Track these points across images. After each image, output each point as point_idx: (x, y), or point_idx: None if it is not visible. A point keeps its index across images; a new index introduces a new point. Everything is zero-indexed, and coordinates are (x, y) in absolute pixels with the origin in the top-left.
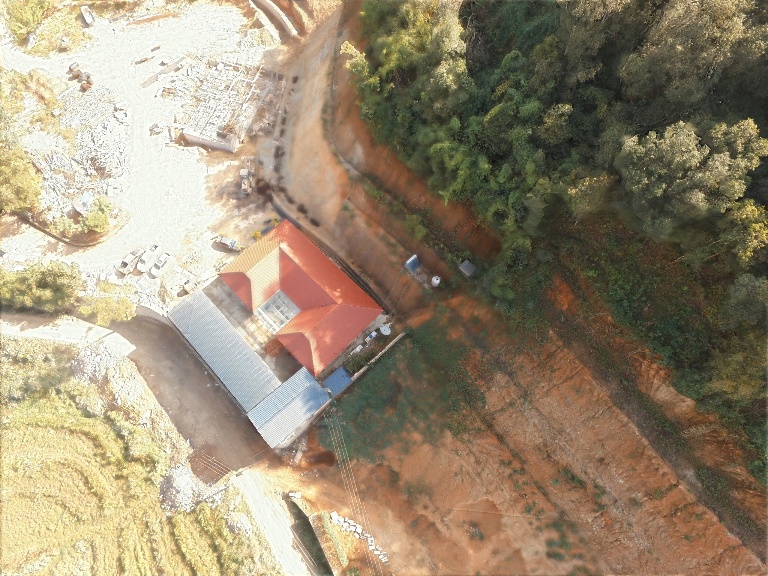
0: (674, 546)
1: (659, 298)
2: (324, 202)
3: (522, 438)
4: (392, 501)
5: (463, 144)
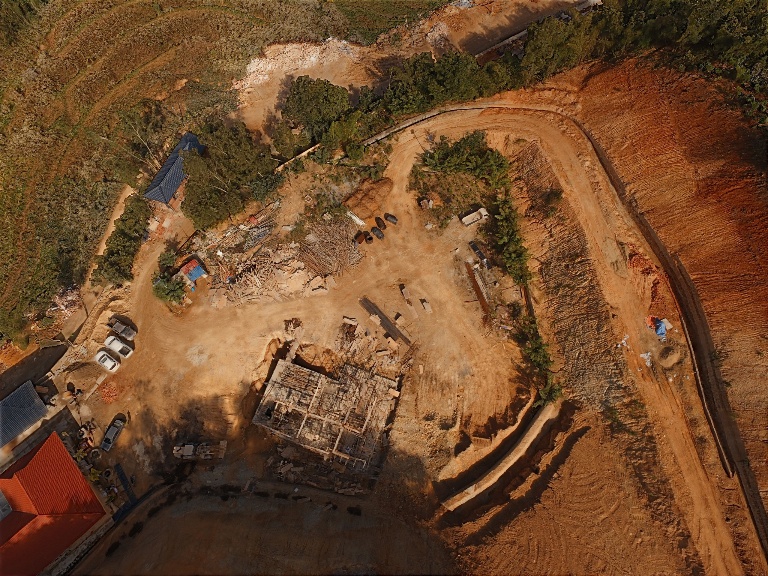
0: None
1: None
2: (116, 570)
3: None
4: None
5: None
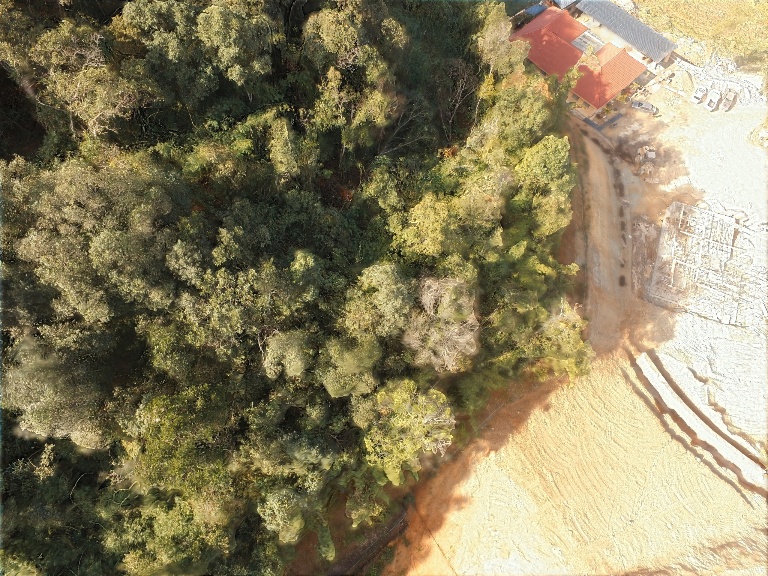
0: None
1: None
2: None
3: None
4: None
5: None
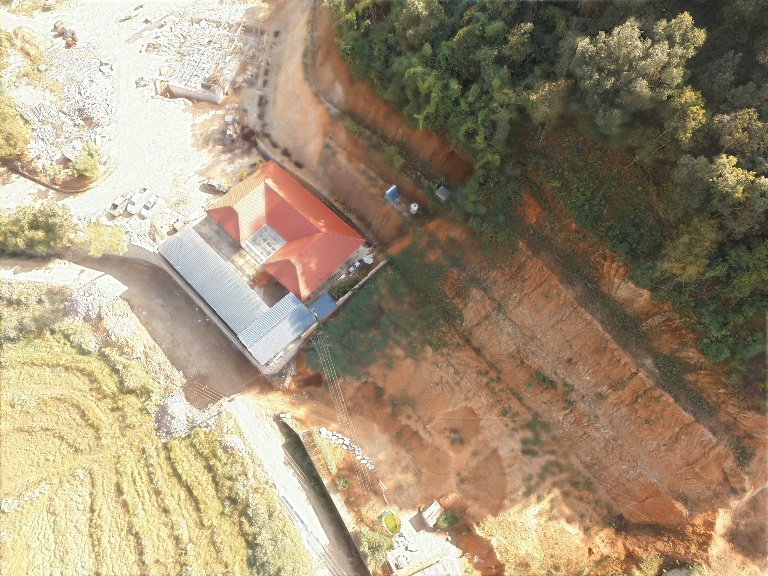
0: (636, 432)
1: (617, 201)
2: (307, 144)
3: (497, 348)
4: (377, 415)
5: (435, 69)
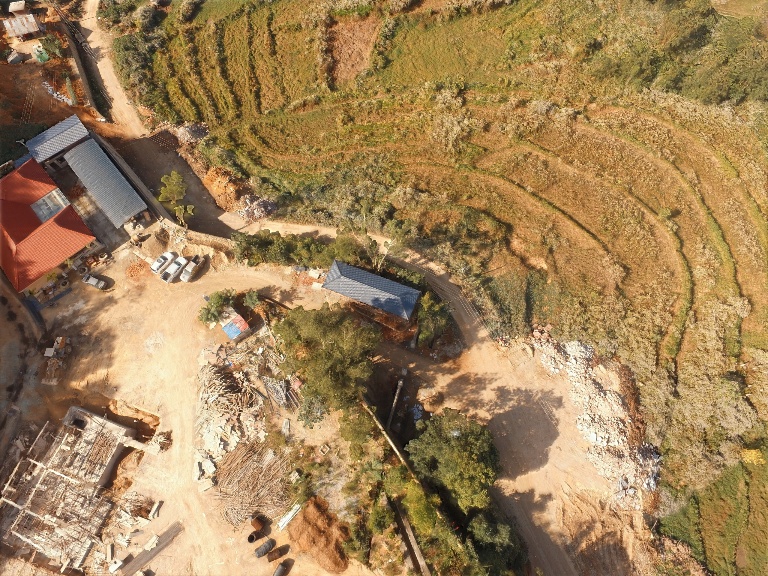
0: None
1: None
2: None
3: None
4: None
5: None
